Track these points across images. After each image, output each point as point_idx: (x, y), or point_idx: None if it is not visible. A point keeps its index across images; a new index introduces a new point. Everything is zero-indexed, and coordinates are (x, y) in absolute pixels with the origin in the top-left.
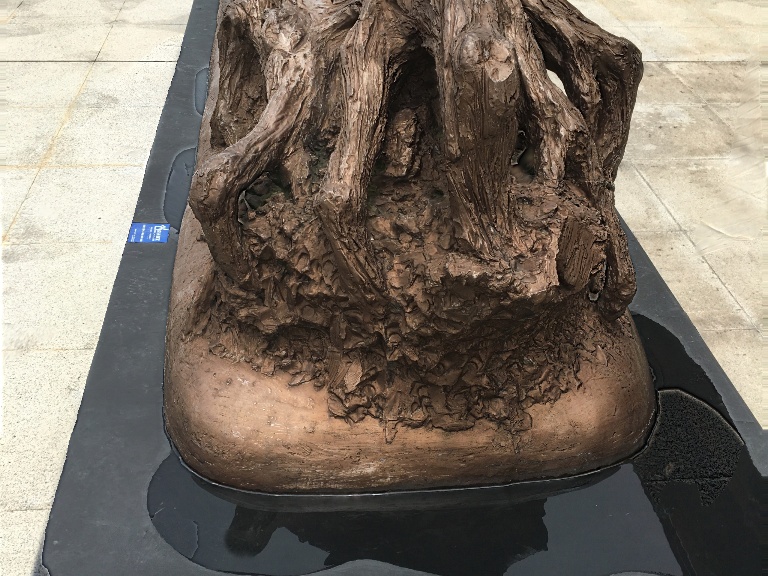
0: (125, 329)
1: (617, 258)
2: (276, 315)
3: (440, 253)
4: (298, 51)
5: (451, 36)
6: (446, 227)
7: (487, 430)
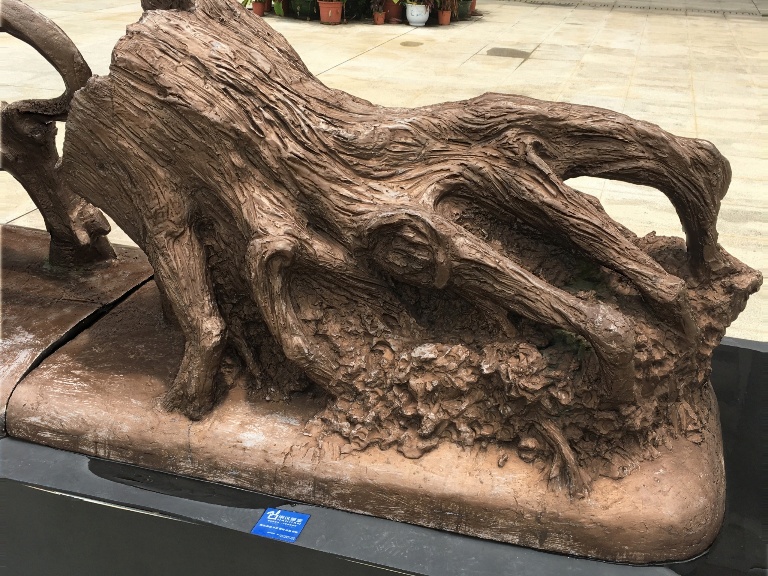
0: (472, 568)
1: None
2: (647, 408)
3: (696, 291)
4: (460, 230)
5: (681, 148)
6: (679, 277)
7: (709, 395)
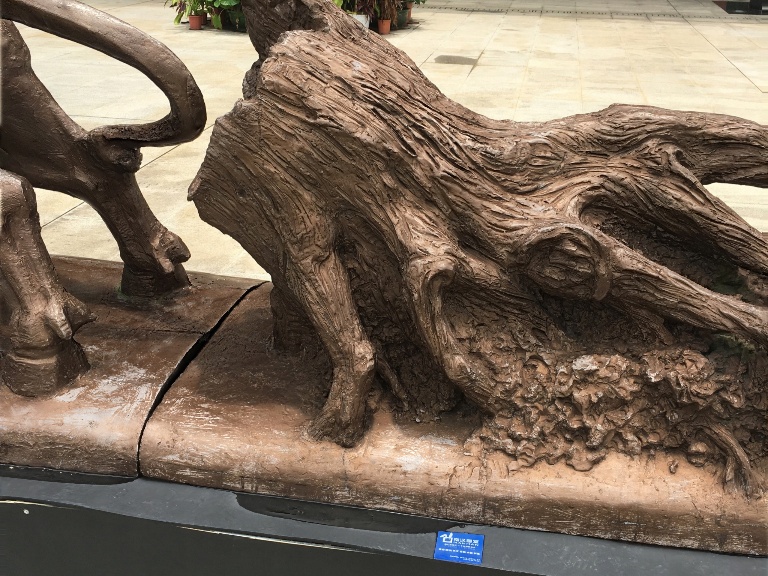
0: (664, 575)
1: None
2: None
3: None
4: (615, 241)
5: None
6: None
7: None
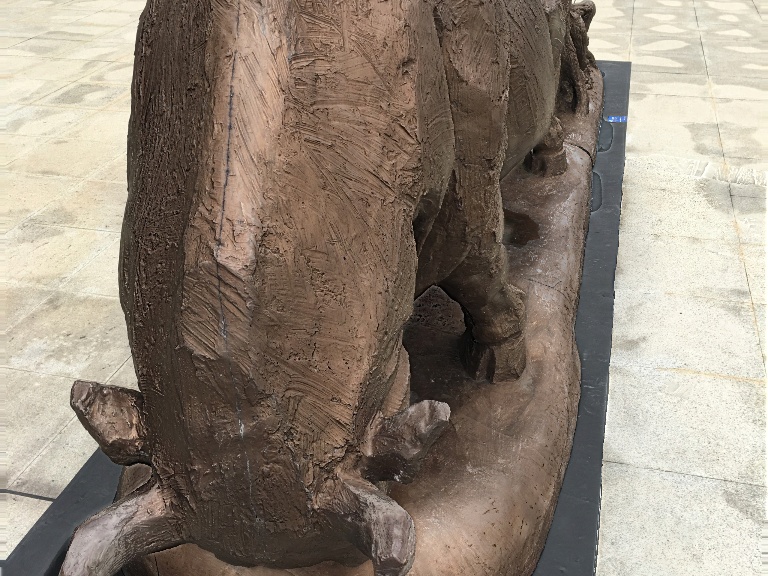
0: None
1: None
2: None
3: None
4: None
5: None
6: None
7: None
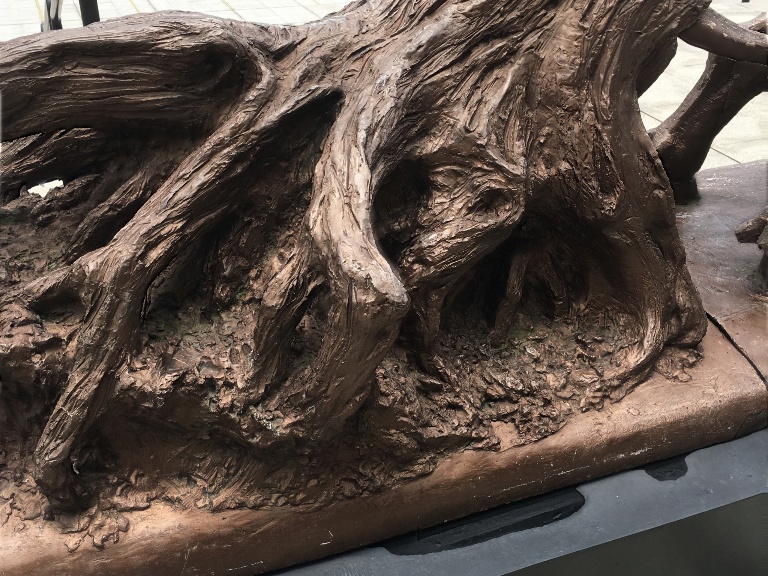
0: None
1: (45, 428)
2: None
3: None
4: None
5: None
6: None
7: None
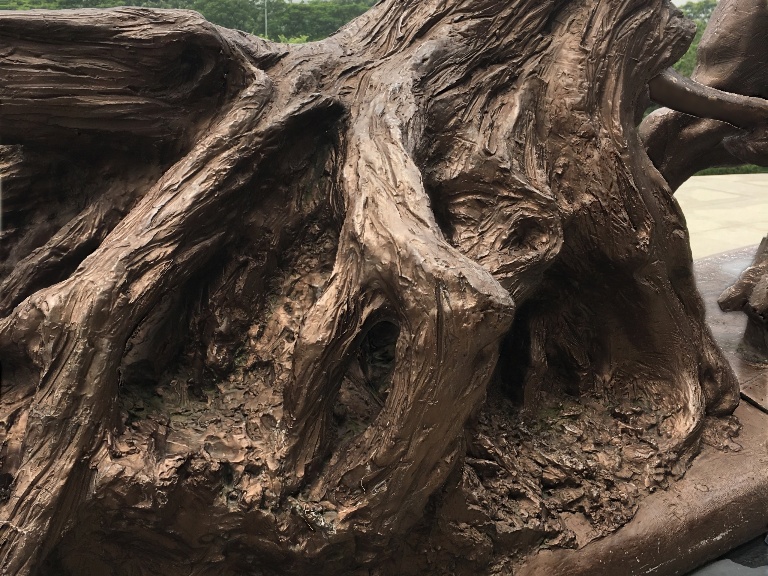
0: None
1: None
2: None
3: None
4: None
5: None
6: None
7: None
